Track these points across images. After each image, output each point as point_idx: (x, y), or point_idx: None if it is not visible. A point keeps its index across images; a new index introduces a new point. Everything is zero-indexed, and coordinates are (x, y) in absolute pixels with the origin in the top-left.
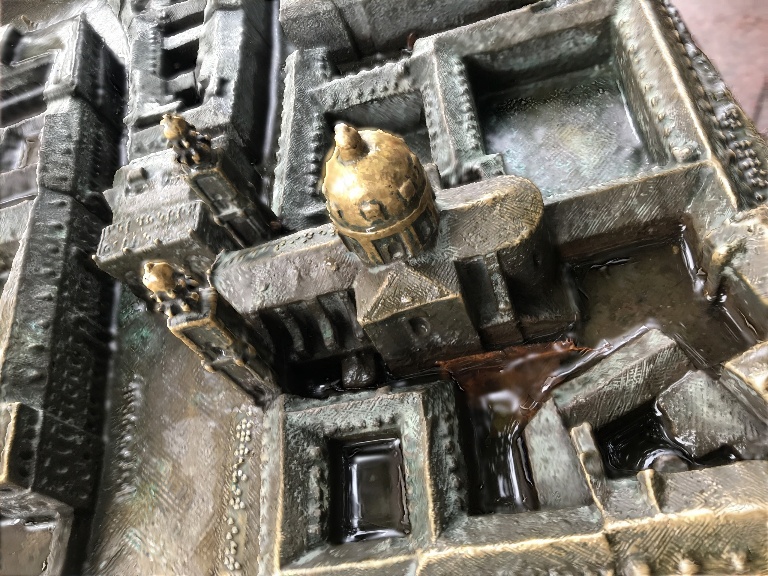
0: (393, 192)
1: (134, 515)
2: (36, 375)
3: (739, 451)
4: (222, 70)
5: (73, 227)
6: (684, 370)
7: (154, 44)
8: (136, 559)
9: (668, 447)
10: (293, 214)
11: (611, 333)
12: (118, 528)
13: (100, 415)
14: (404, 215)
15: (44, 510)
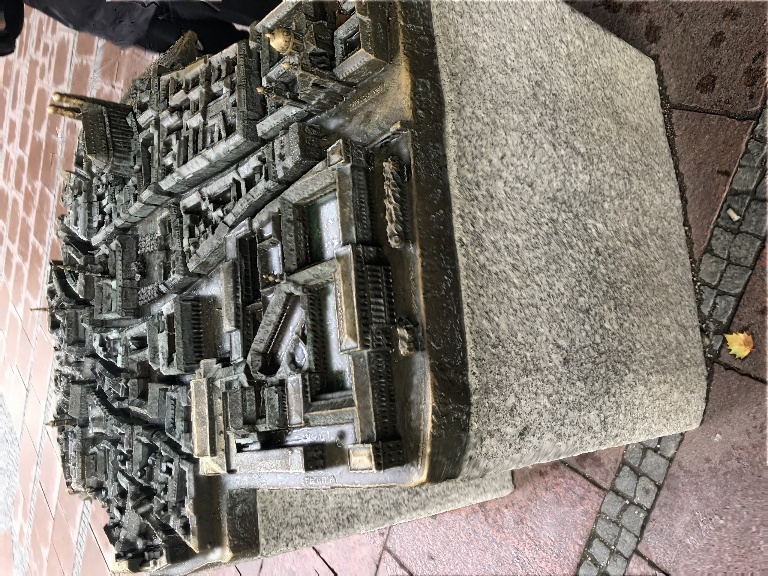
0: (283, 28)
1: None
2: None
3: None
4: None
5: None
6: None
7: None
8: None
9: None
10: None
11: None
12: None
13: None
14: (289, 30)
15: (363, 152)
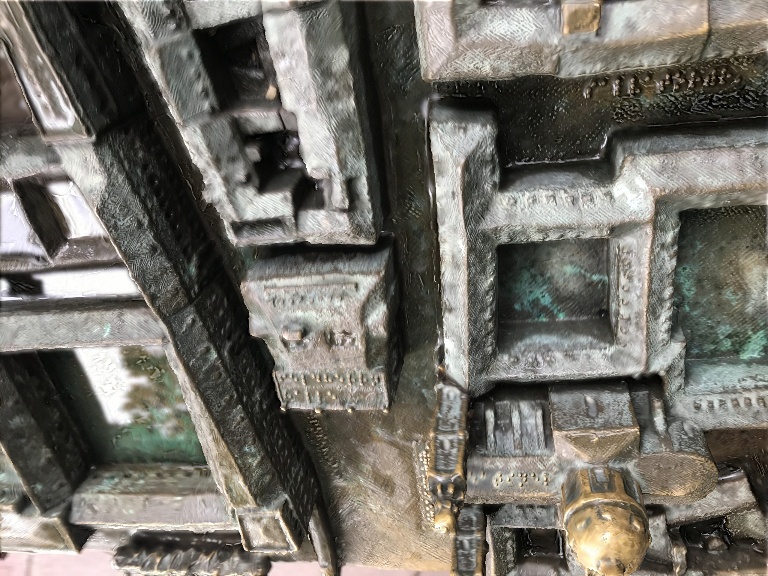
0: None
1: (352, 490)
2: (270, 478)
3: (758, 542)
4: (345, 163)
5: (212, 335)
6: (751, 508)
7: (178, 30)
8: (364, 511)
9: (720, 530)
10: (477, 382)
11: (712, 447)
12: (343, 496)
13: (297, 438)
14: None
15: None
